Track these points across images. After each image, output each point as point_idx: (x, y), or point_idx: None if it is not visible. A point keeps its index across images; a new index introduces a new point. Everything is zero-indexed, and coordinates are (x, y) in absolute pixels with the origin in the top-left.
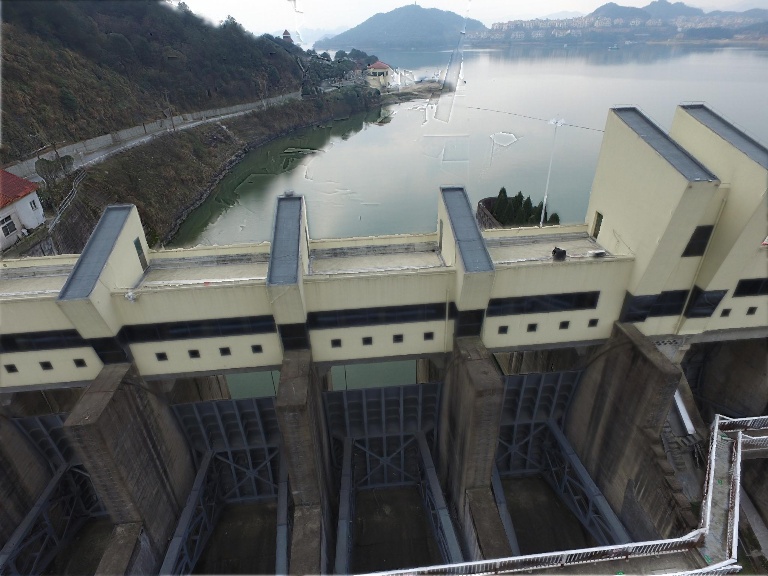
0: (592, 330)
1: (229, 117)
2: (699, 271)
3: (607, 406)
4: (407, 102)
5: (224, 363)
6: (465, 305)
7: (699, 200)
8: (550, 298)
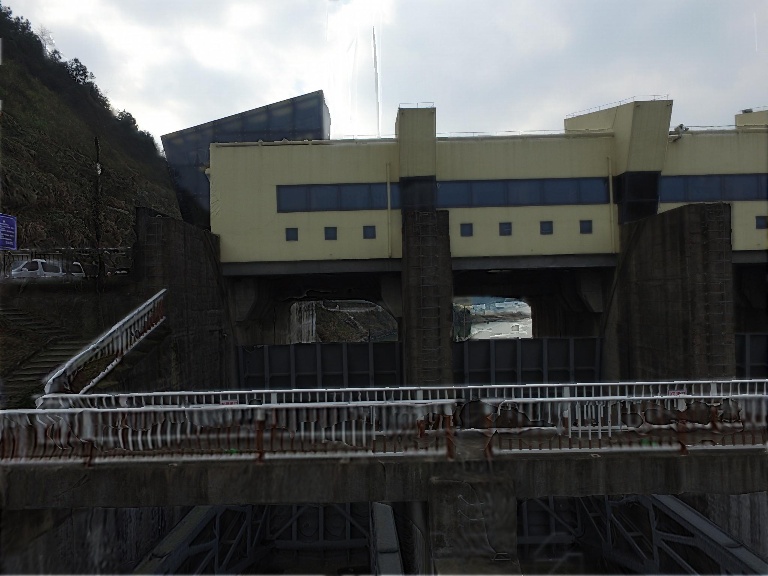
0: None
1: (353, 312)
2: None
3: None
4: (495, 322)
5: (757, 241)
6: None
7: None
8: None
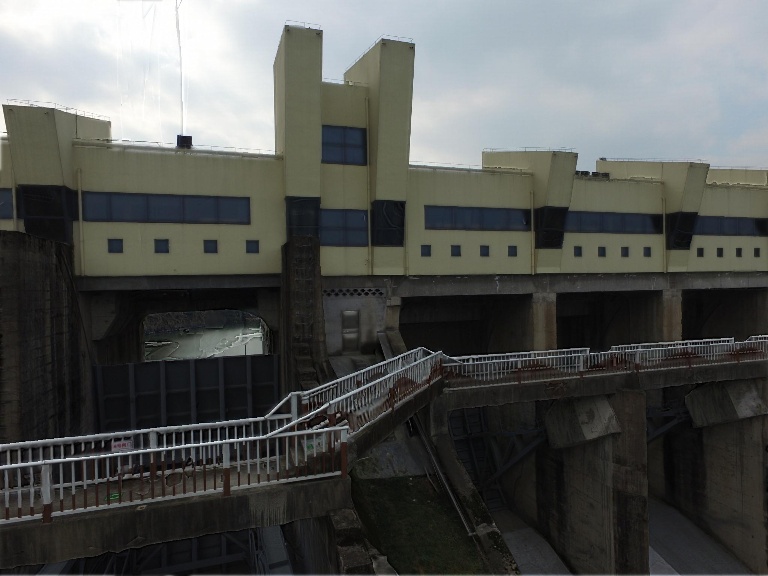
0: (254, 258)
1: None
2: (369, 184)
3: (286, 368)
4: None
5: None
6: (25, 173)
7: (308, 54)
8: (181, 201)
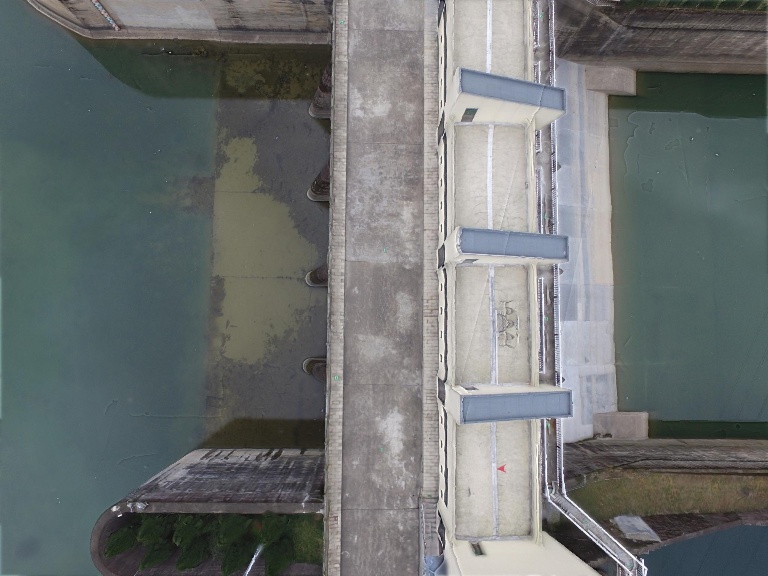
0: None
1: None
2: None
3: None
4: None
5: None
6: None
7: None
8: None
